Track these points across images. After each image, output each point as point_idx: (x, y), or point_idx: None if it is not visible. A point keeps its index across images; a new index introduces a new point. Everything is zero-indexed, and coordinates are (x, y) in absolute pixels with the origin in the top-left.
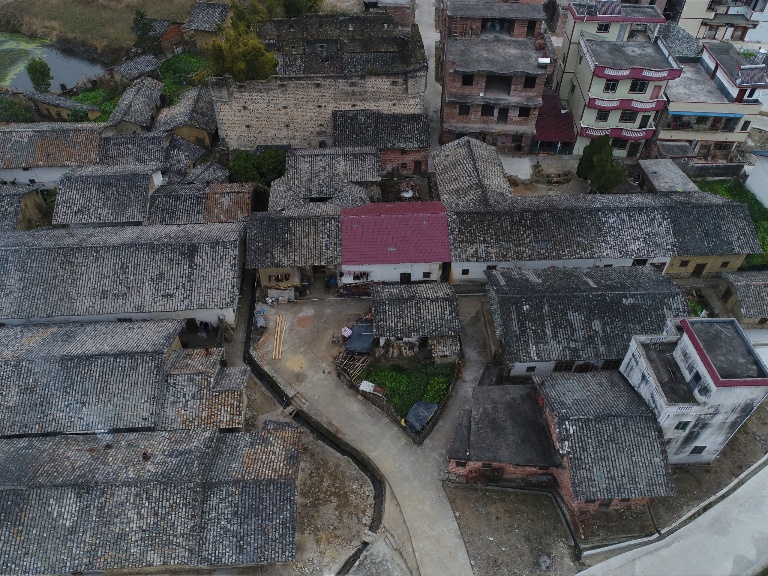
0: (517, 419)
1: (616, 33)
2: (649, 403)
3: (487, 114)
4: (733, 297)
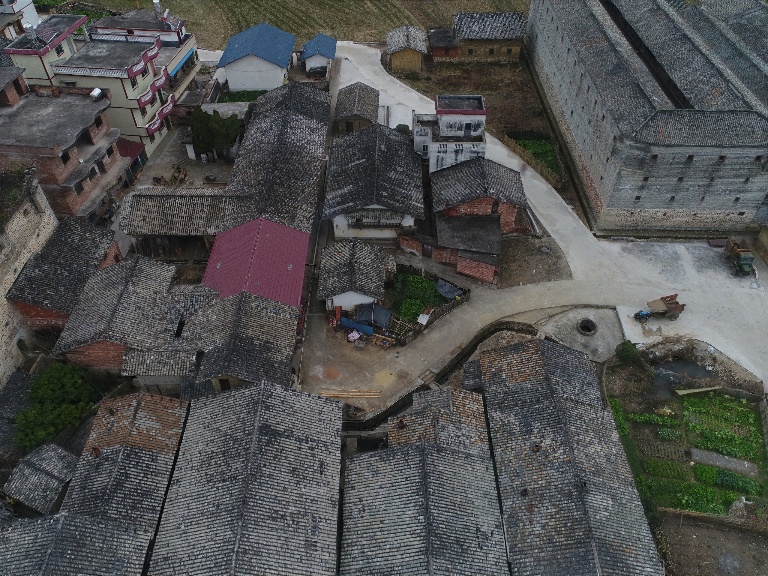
0: (466, 228)
1: (68, 49)
2: (472, 157)
3: (91, 176)
4: (355, 123)
